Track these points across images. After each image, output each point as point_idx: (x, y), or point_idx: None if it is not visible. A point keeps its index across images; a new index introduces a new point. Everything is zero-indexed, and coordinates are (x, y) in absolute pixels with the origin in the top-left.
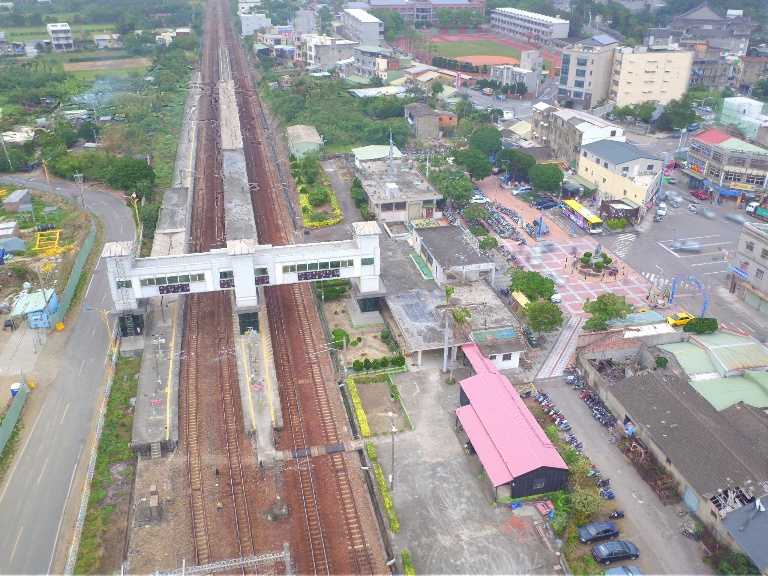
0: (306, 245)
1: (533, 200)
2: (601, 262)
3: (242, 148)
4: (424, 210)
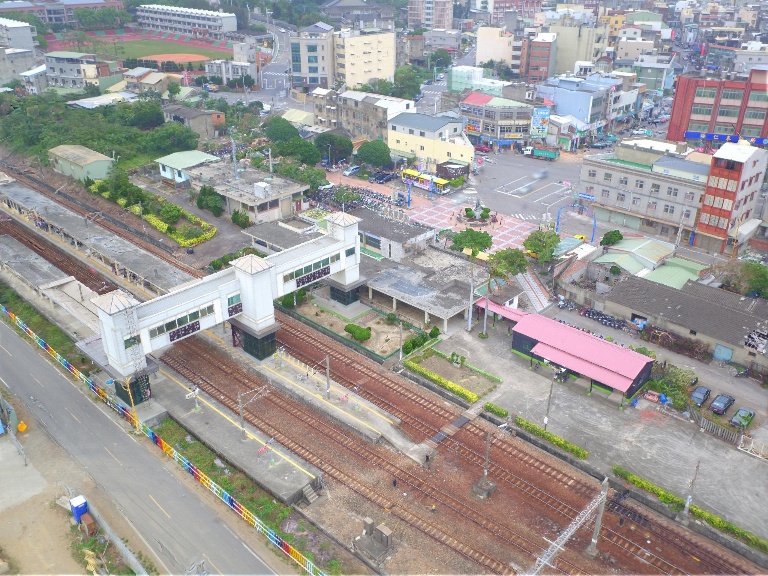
0: (288, 250)
1: (370, 177)
2: None
3: (16, 181)
4: (294, 204)
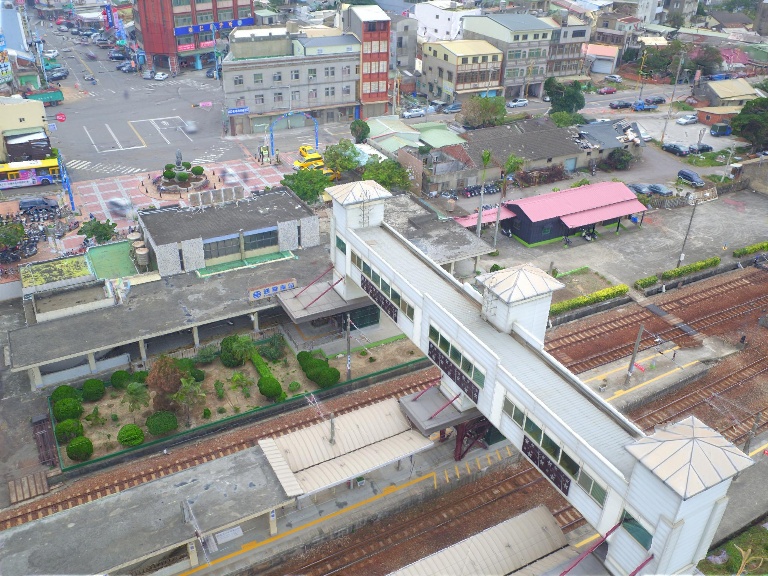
0: None
1: None
2: (198, 166)
3: None
4: None
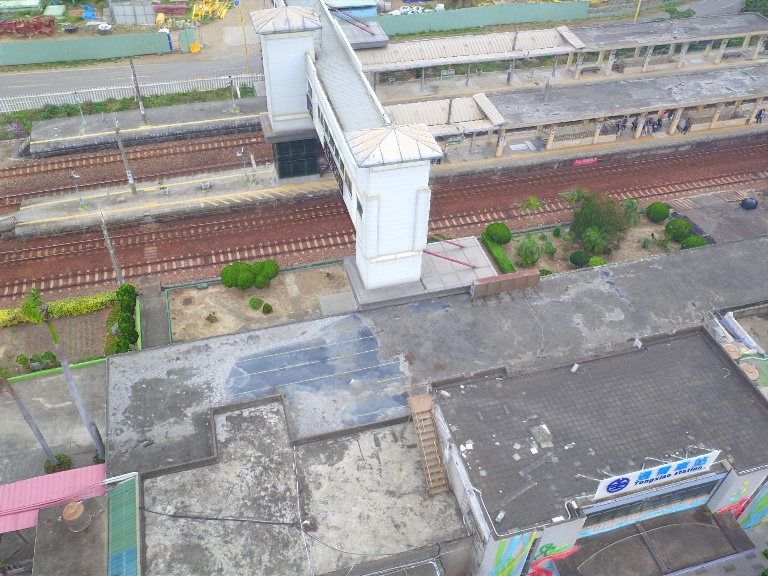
0: (378, 106)
1: None
2: None
3: None
4: None
